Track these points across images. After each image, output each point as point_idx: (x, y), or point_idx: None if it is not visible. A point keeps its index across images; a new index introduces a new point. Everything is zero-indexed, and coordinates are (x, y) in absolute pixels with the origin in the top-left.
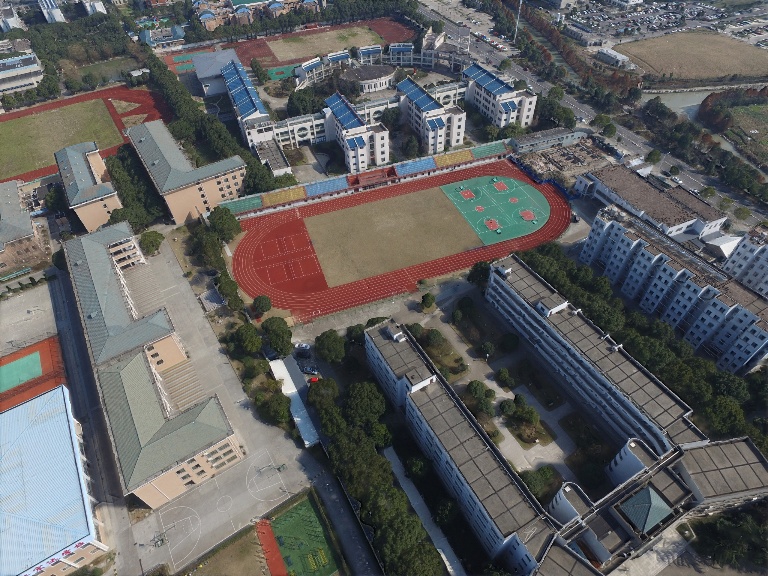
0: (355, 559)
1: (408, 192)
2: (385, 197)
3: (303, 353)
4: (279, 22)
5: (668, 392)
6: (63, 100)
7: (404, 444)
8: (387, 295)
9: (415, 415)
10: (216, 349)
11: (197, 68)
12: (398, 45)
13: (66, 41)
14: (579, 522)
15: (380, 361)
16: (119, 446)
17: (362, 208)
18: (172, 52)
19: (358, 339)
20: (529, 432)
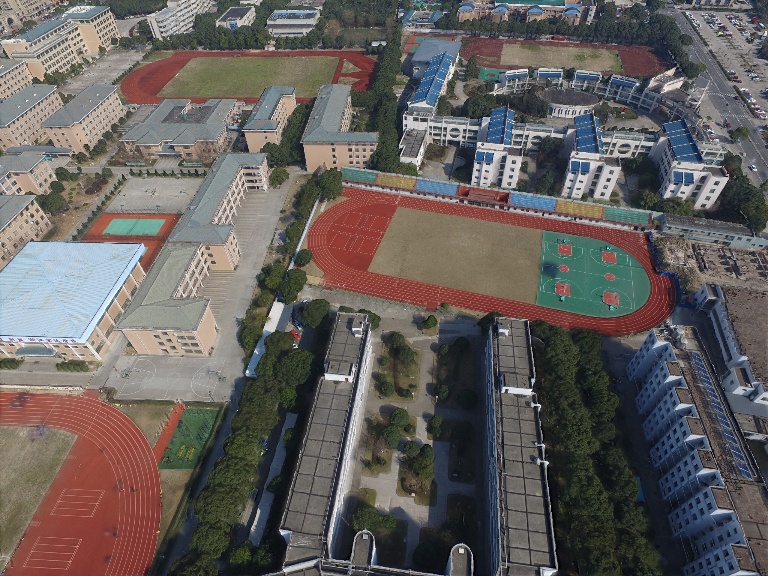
0: None
1: (508, 223)
2: (482, 218)
3: (303, 309)
4: (527, 27)
5: (551, 536)
6: (315, 51)
7: None
8: (406, 301)
9: None
10: (255, 274)
11: (418, 51)
12: (621, 78)
13: (350, 6)
14: (347, 567)
15: None
16: (136, 298)
17: (453, 219)
18: (420, 33)
19: None
20: (414, 483)
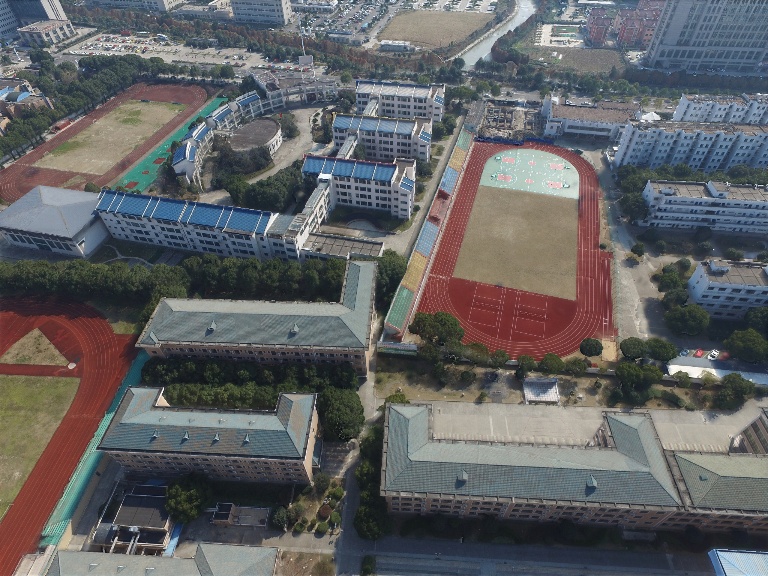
0: None
1: (472, 202)
2: (467, 216)
3: None
4: (21, 135)
5: None
6: None
7: None
8: (607, 271)
9: None
10: None
11: (39, 229)
12: (243, 97)
13: None
14: None
15: (736, 292)
16: None
17: (471, 235)
18: None
19: None
20: None
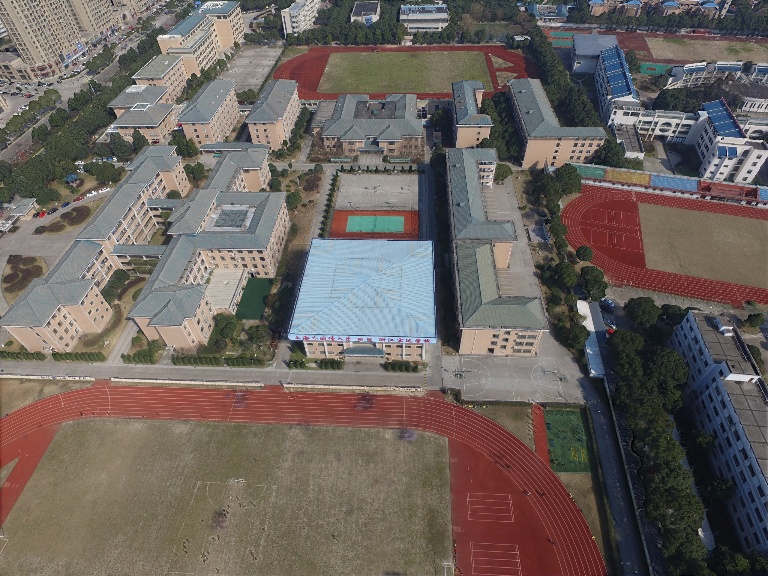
0: (608, 475)
1: (763, 218)
2: (733, 214)
3: (607, 307)
4: (668, 20)
5: None
6: (454, 46)
7: (685, 421)
8: (706, 298)
9: (718, 399)
10: (531, 271)
11: (577, 45)
12: None
13: None
14: None
15: (695, 342)
16: (463, 296)
17: (704, 215)
18: (551, 27)
19: (672, 317)
20: None
